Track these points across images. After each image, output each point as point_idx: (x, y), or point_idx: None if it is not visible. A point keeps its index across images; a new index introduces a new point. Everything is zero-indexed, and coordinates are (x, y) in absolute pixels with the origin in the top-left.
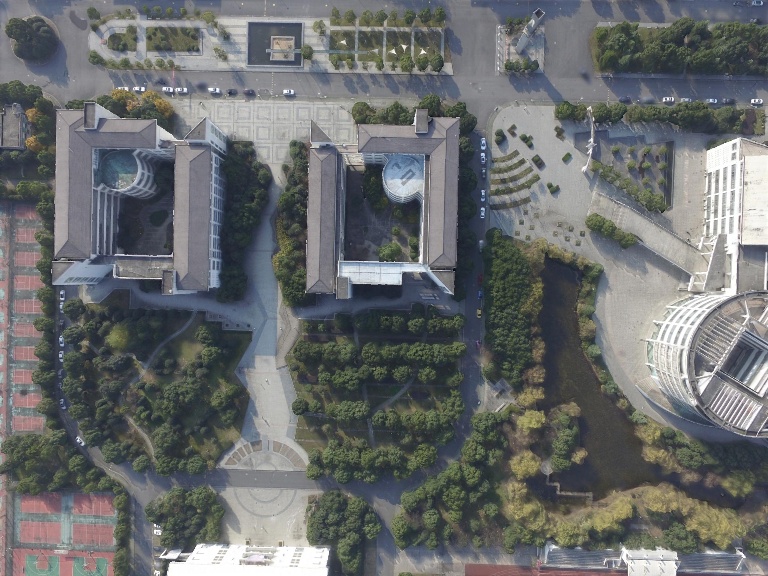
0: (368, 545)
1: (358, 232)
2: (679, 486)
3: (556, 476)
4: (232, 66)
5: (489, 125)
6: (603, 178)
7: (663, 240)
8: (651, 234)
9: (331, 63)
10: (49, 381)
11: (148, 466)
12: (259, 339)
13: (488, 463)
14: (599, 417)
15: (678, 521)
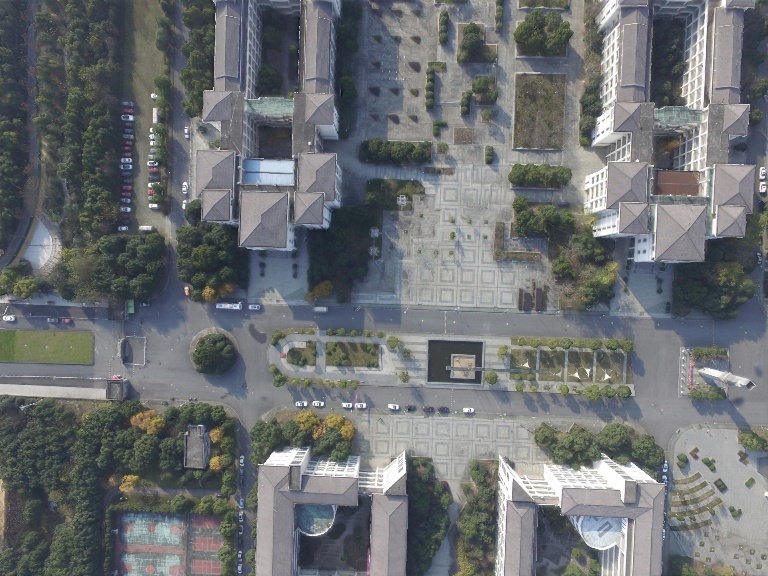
0: None
1: None
2: None
3: None
4: (412, 383)
5: (671, 447)
6: None
7: None
8: None
9: (512, 383)
10: None
11: None
12: None
13: None
14: None
15: None
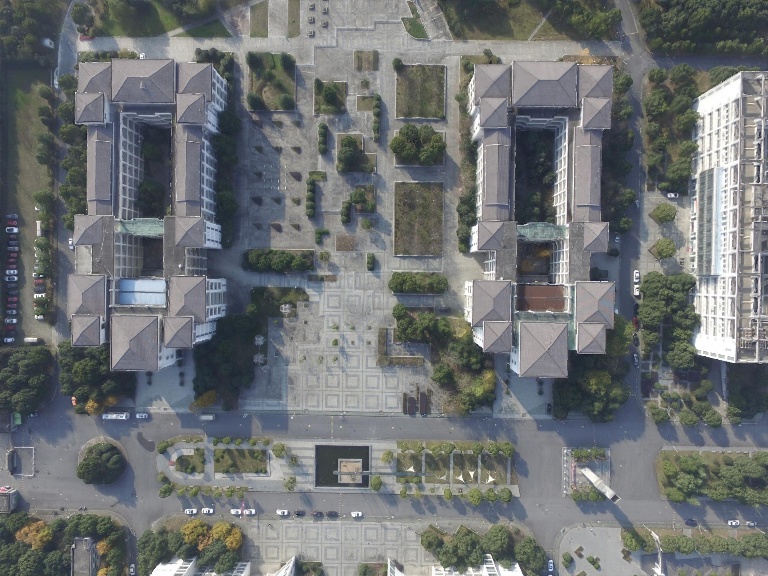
0: None
1: None
2: None
3: None
4: (300, 488)
5: (556, 546)
6: None
7: None
8: None
9: (398, 486)
10: None
11: None
12: None
13: None
14: None
15: None
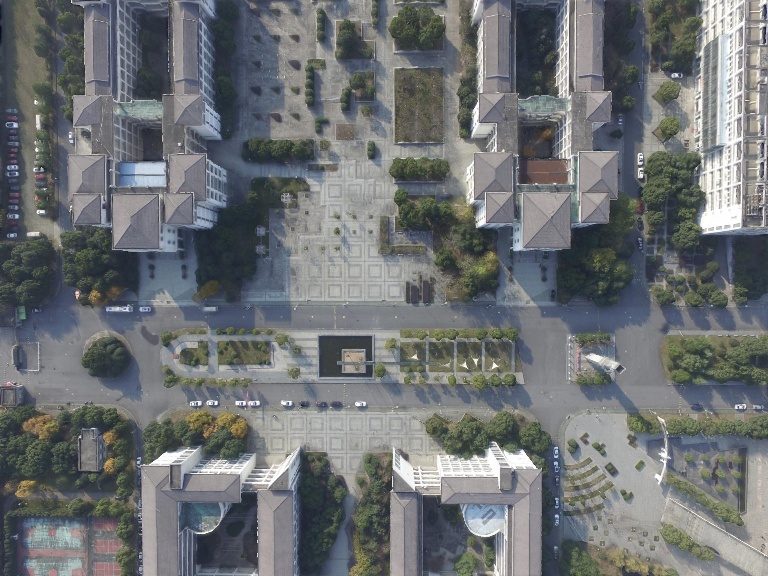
0: None
1: (433, 540)
2: None
3: None
4: (304, 379)
5: (561, 433)
6: (676, 484)
7: (739, 552)
8: (727, 546)
9: (402, 375)
10: None
11: None
12: None
13: None
14: None
15: None
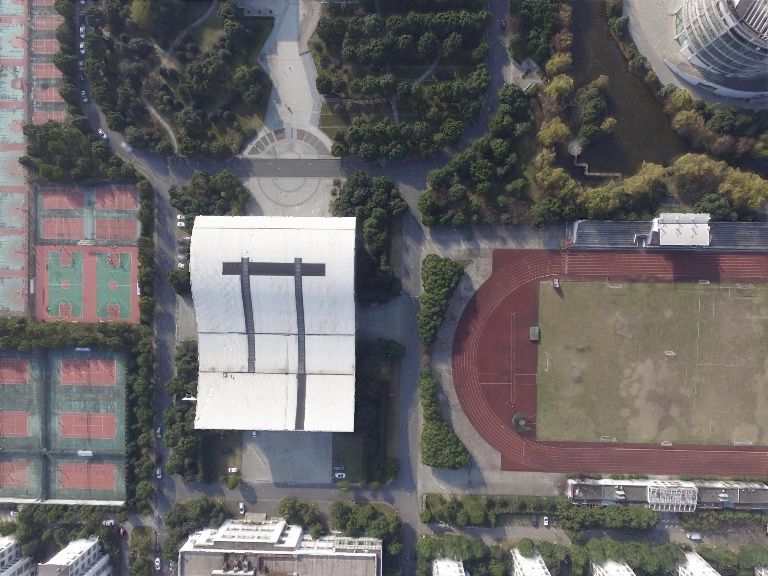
0: (394, 233)
1: None
2: (710, 156)
3: (584, 159)
4: None
5: None
6: None
7: None
8: None
9: None
10: (71, 62)
11: (171, 150)
12: (281, 25)
13: (515, 133)
14: (627, 97)
15: (709, 193)
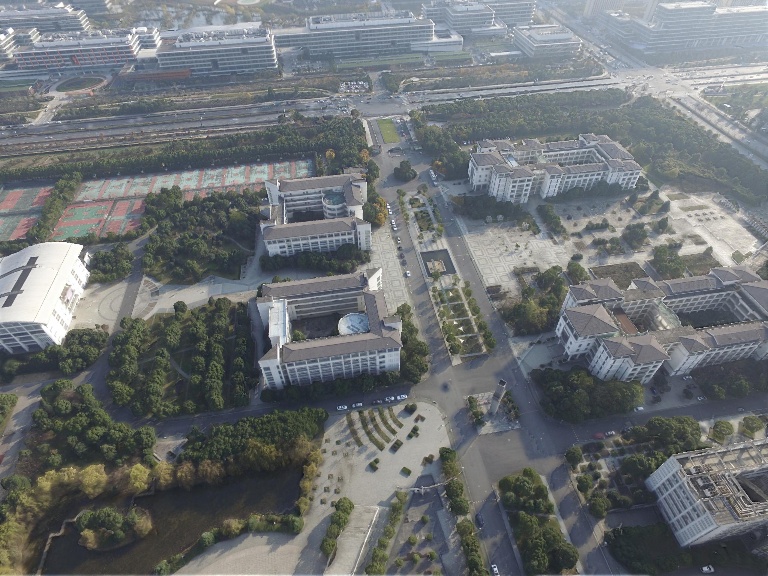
0: (53, 373)
1: (316, 326)
2: None
3: (71, 531)
4: (417, 246)
5: (420, 399)
6: None
7: None
8: (339, 574)
9: None
10: (213, 197)
11: (152, 242)
12: (234, 284)
13: None
14: (129, 569)
15: None
